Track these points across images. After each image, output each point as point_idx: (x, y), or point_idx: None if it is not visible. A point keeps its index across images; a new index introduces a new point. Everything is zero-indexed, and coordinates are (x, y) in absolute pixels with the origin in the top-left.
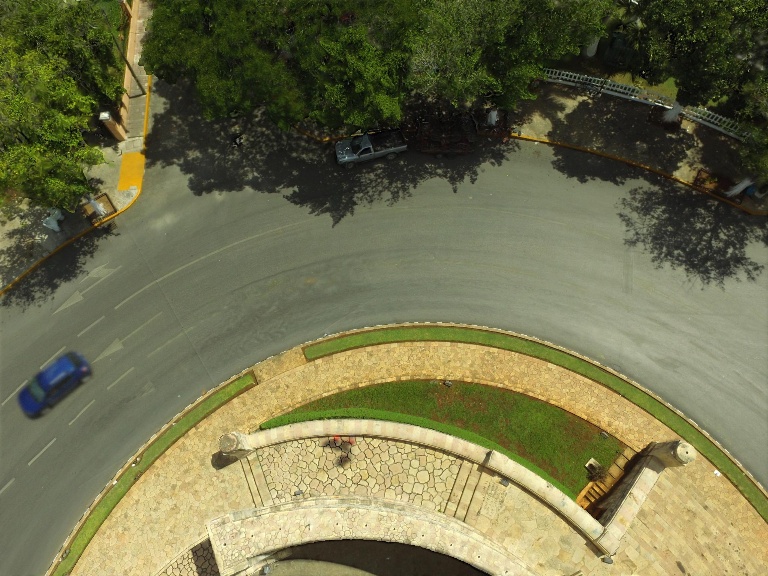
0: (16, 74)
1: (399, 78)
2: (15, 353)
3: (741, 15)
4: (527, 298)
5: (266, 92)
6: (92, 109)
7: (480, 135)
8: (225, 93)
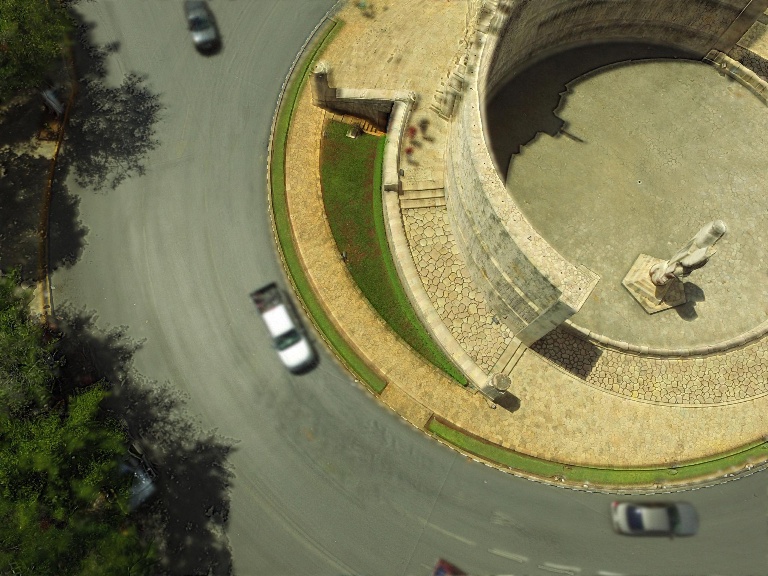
0: None
1: None
2: None
3: None
4: (235, 230)
5: (117, 568)
6: None
7: None
8: None
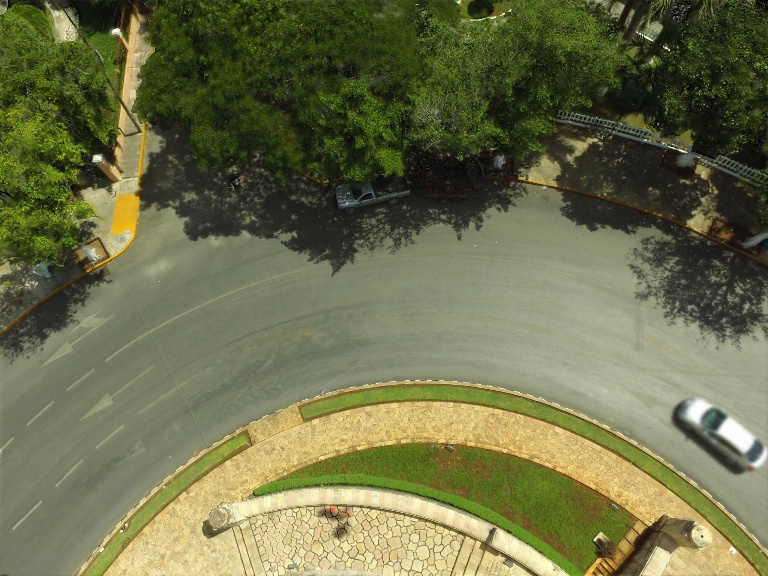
0: (0, 133)
1: (402, 129)
2: (2, 408)
3: (763, 72)
4: (533, 355)
5: (263, 143)
6: (83, 158)
7: (486, 178)
8: (220, 144)
